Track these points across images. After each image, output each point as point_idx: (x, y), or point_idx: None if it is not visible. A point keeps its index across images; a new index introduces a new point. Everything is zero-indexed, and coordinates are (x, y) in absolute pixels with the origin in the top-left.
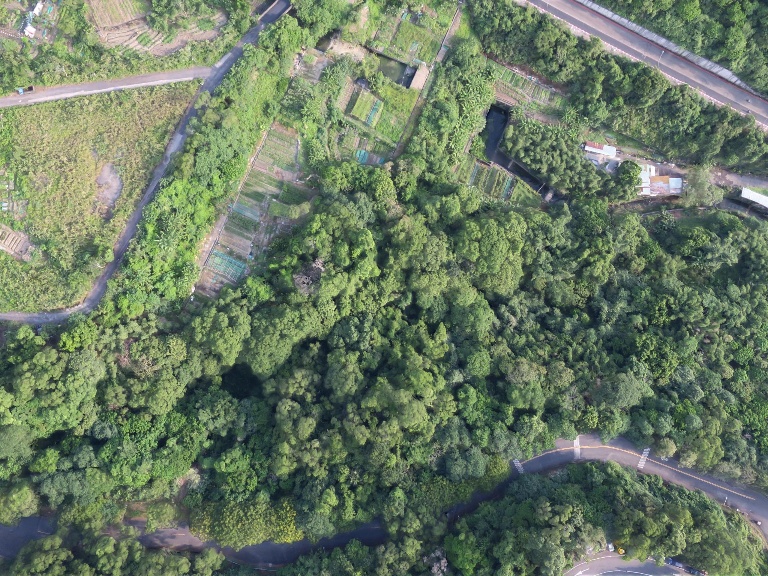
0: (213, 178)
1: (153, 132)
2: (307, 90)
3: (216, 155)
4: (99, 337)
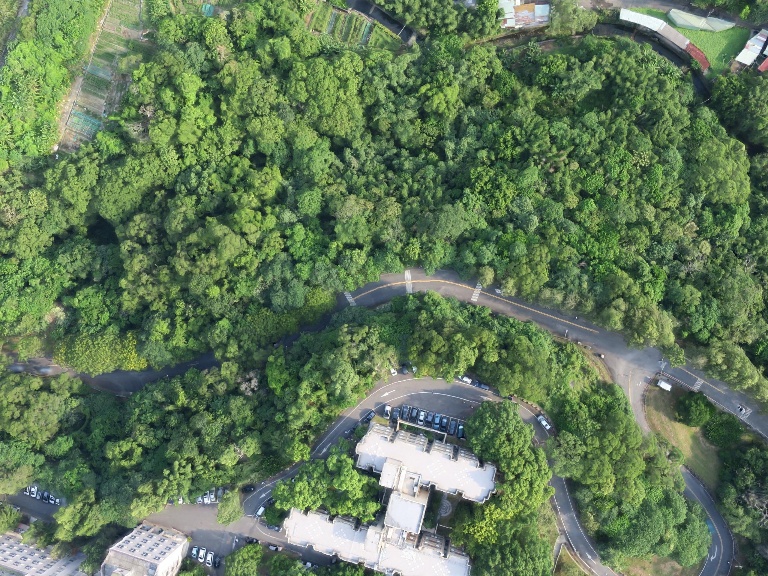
0: (55, 39)
1: (4, 2)
2: None
3: (56, 17)
4: None
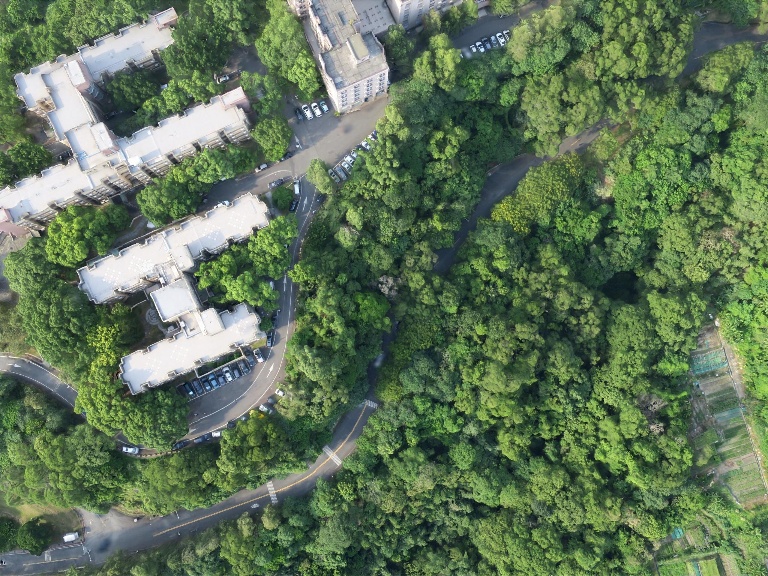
0: None
1: None
2: None
3: None
4: (764, 236)
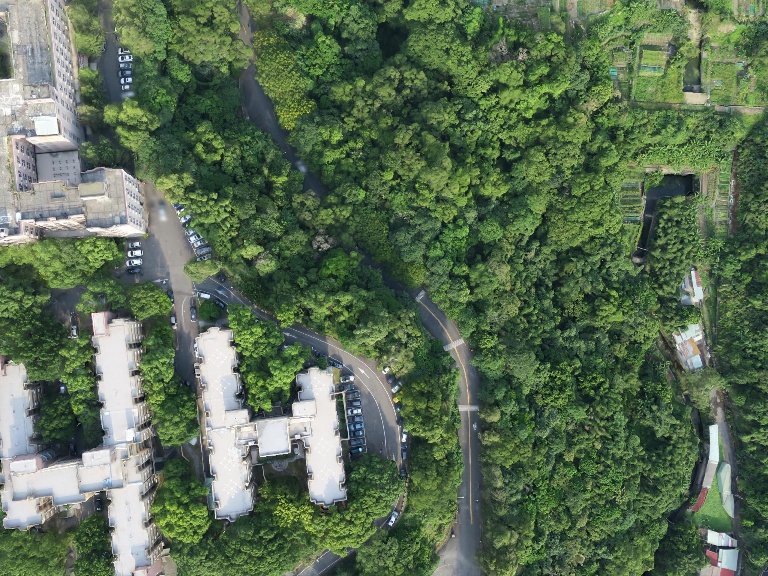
0: None
1: None
2: (650, 1)
3: None
4: None
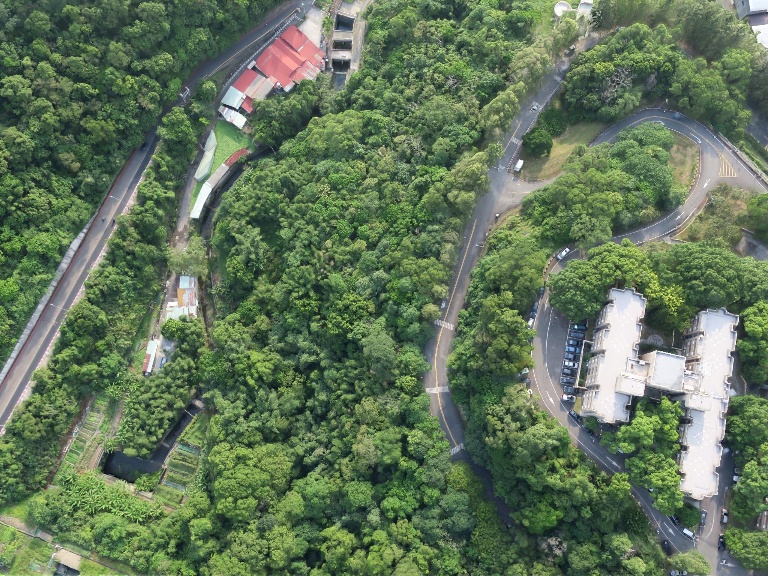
0: None
1: None
2: None
3: None
4: None
